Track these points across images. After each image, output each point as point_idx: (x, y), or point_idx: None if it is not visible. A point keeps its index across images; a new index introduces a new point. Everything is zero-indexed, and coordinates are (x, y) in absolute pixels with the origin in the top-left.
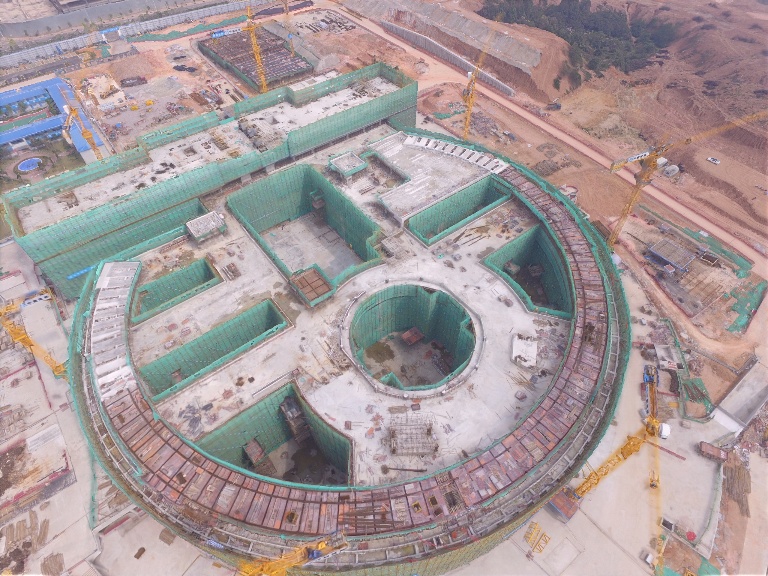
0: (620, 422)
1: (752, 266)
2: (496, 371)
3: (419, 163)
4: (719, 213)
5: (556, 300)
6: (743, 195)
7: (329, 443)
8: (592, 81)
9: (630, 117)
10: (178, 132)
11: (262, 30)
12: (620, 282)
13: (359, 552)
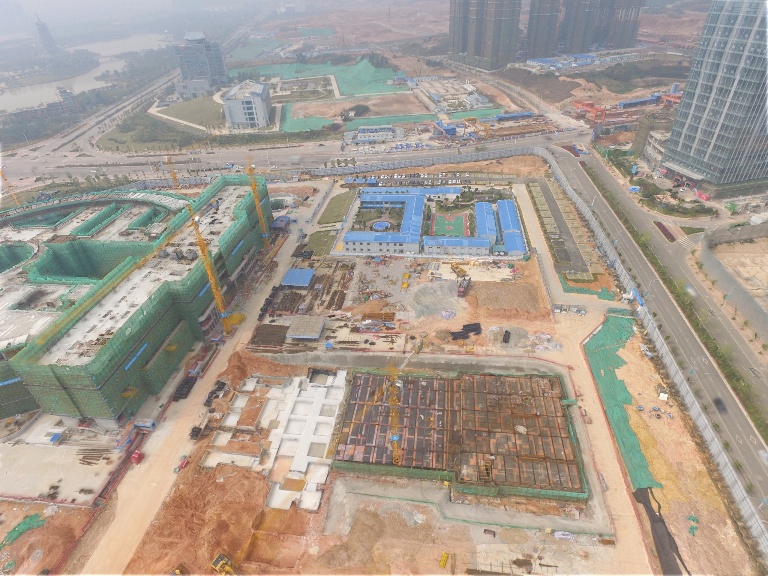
0: None
1: None
2: None
3: (4, 327)
4: None
5: None
6: None
7: None
8: None
9: None
10: (235, 230)
11: (556, 480)
12: None
13: None
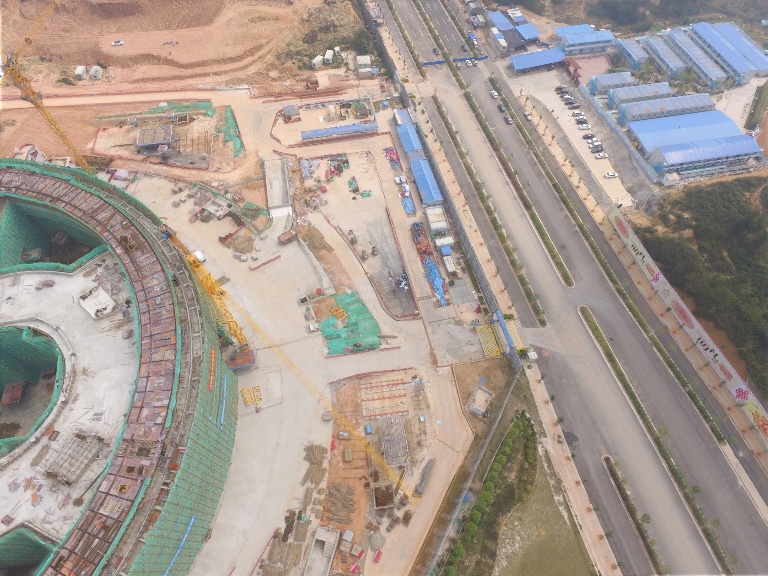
0: (230, 276)
1: (211, 103)
2: (92, 339)
3: None
4: (159, 81)
5: (97, 244)
6: (161, 56)
7: (20, 551)
8: None
9: None
10: None
11: None
12: (117, 188)
13: (119, 570)
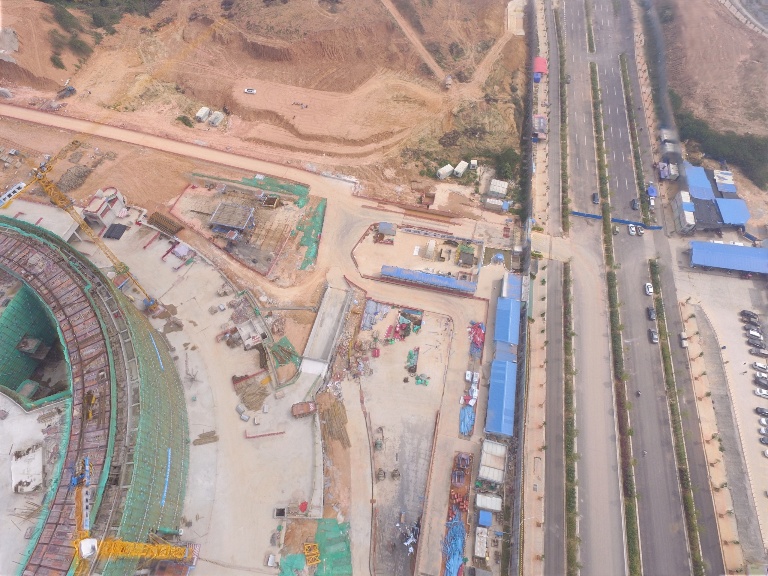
0: (221, 434)
1: (309, 189)
2: None
3: None
4: (270, 146)
5: None
6: (285, 118)
7: None
8: (105, 42)
9: (159, 72)
10: None
11: None
12: None
13: None
